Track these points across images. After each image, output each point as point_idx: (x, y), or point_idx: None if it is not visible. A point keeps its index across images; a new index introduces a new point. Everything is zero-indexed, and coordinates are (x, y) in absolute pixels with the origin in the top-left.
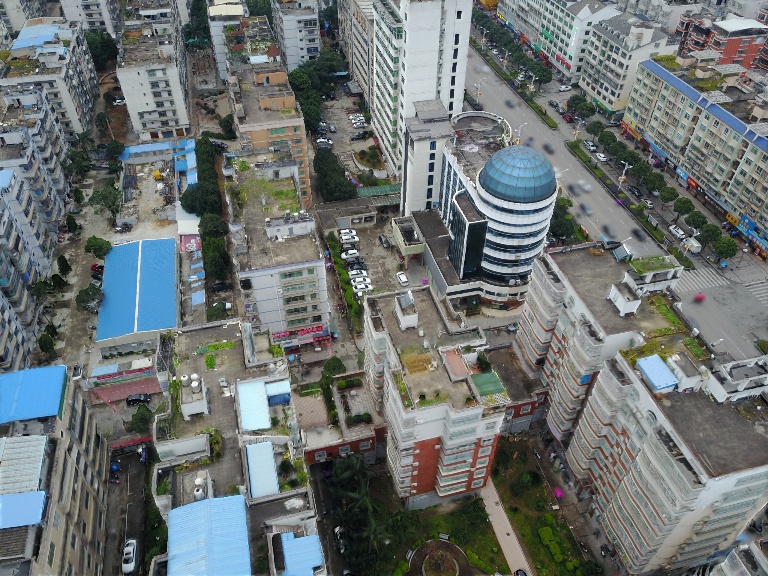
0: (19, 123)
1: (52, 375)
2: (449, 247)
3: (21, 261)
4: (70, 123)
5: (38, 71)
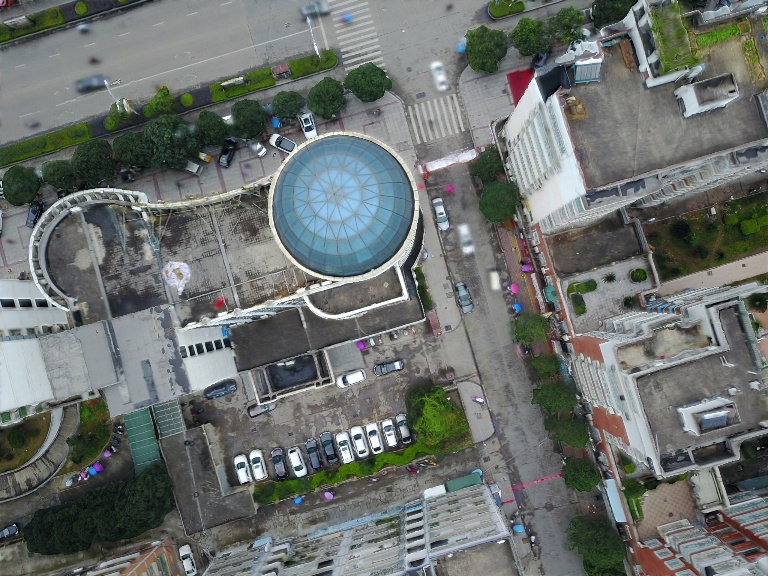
0: None
1: None
2: None
3: None
4: None
5: None
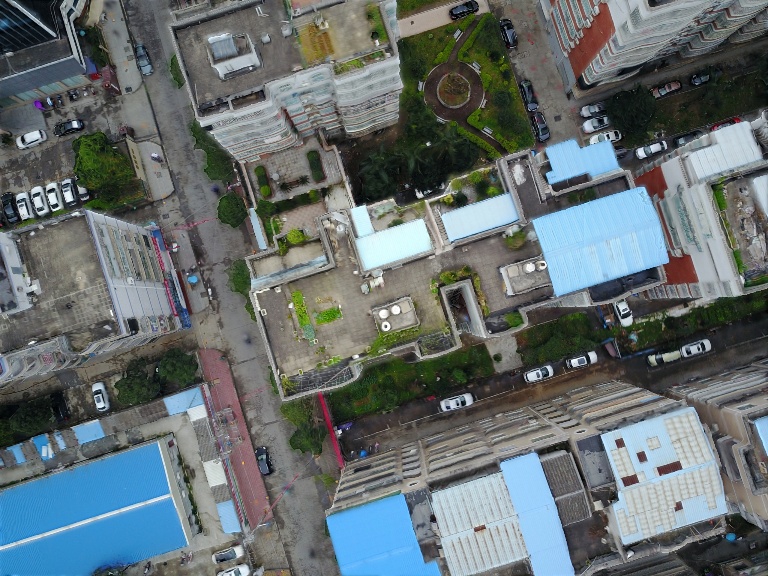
0: None
1: (344, 527)
2: None
3: None
4: None
5: None
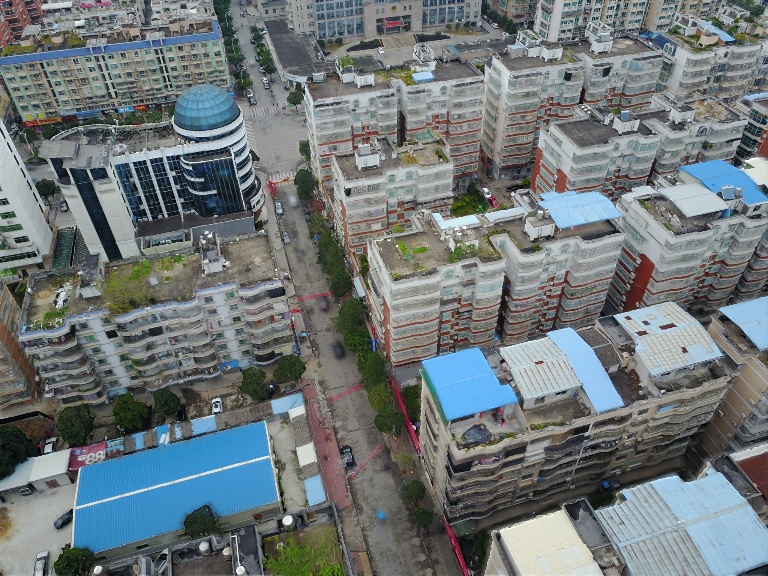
0: None
1: (436, 365)
2: (206, 210)
3: None
4: None
5: None
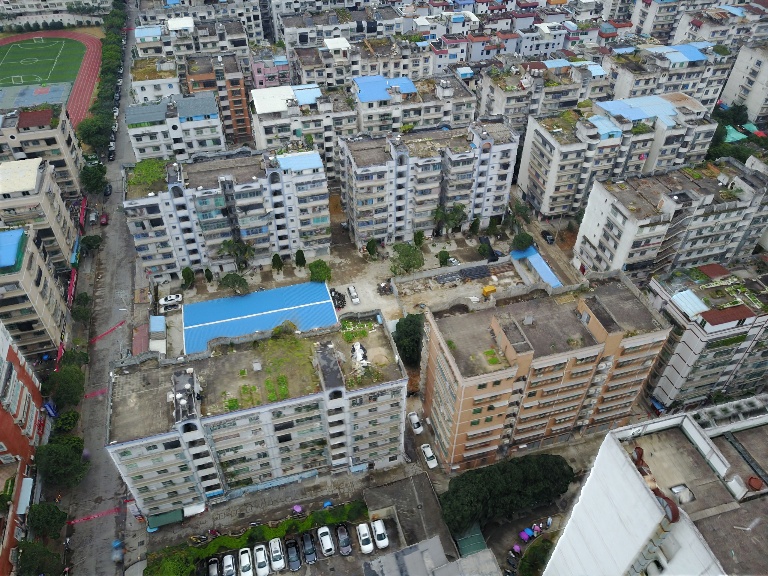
0: (431, 149)
1: (5, 260)
2: None
3: (244, 220)
4: (544, 193)
5: (558, 131)
